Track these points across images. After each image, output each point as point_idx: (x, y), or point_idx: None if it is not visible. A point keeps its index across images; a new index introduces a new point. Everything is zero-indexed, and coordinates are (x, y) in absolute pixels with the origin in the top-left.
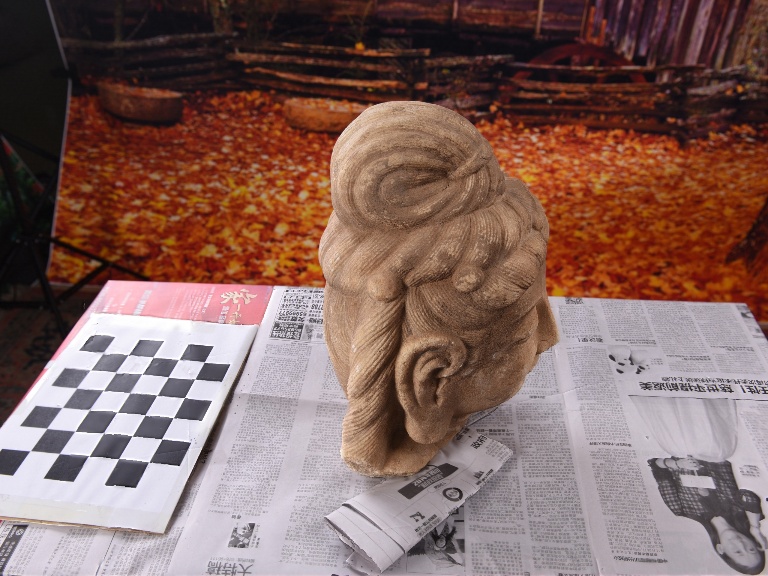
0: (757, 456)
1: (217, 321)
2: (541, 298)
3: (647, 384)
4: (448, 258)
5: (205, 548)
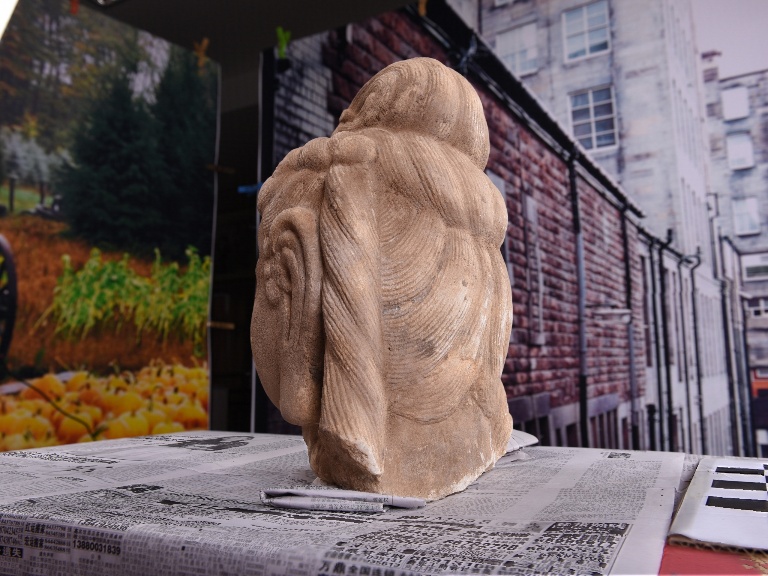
0: None
1: None
2: None
3: (108, 462)
4: None
5: None
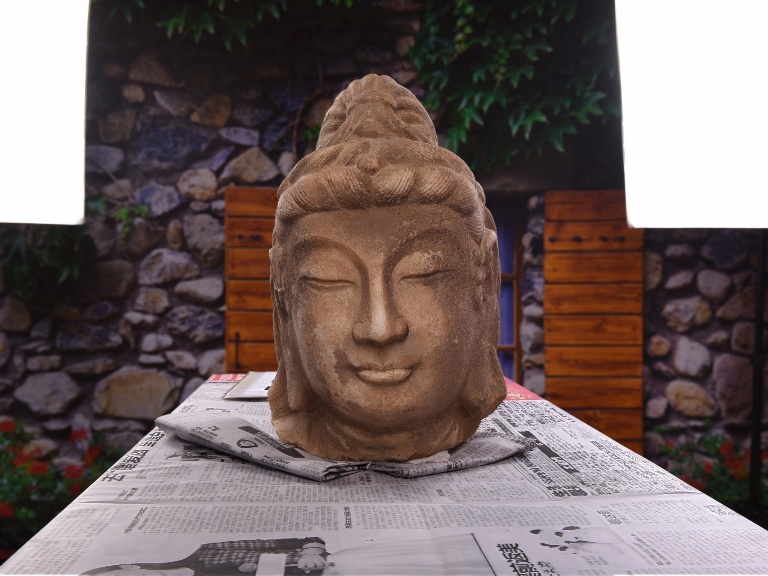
0: None
1: None
2: (352, 252)
3: (515, 548)
4: None
5: (208, 404)
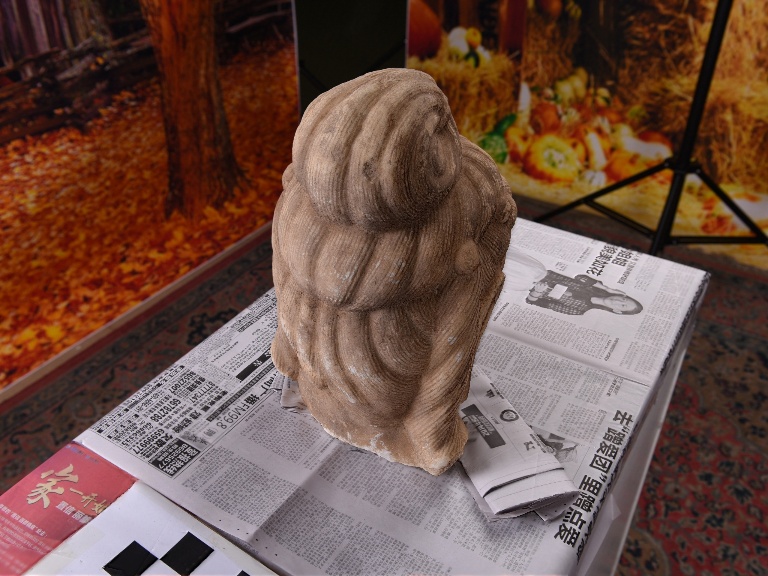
0: (550, 257)
1: (80, 524)
2: None
3: None
4: (493, 198)
5: None
